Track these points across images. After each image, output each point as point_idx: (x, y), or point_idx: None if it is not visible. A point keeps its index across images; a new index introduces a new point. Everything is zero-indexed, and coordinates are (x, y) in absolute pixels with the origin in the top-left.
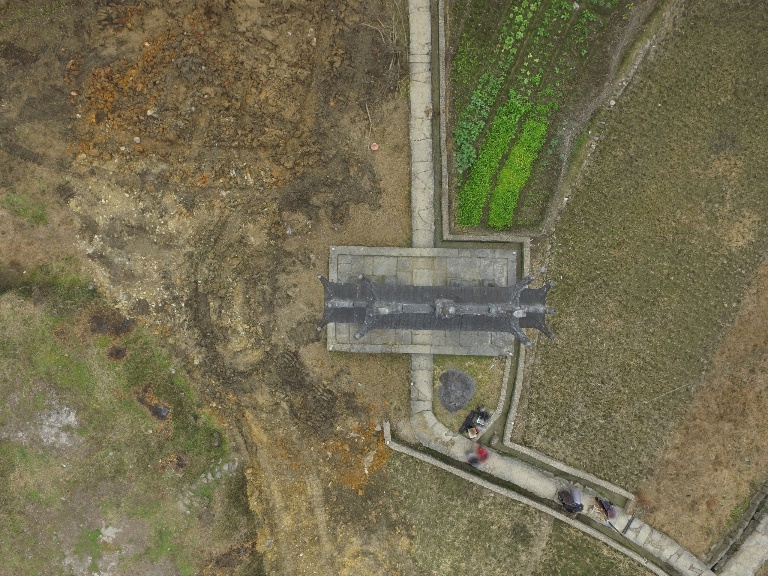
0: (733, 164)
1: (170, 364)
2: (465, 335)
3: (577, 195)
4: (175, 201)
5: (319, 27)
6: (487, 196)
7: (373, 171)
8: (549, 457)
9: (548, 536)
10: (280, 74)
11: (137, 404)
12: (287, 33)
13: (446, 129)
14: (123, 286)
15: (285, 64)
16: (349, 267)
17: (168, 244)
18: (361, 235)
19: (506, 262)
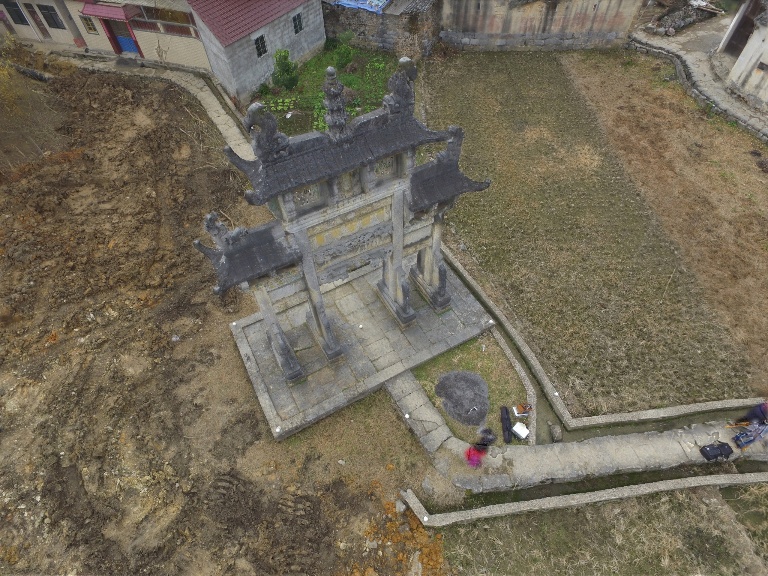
0: (539, 131)
1: None
2: (431, 331)
3: None
4: (15, 377)
5: (155, 185)
6: None
7: None
8: (632, 412)
9: (738, 522)
10: (126, 224)
11: None
12: (125, 199)
13: None
14: None
15: (129, 217)
16: (261, 334)
17: (7, 428)
18: None
19: None
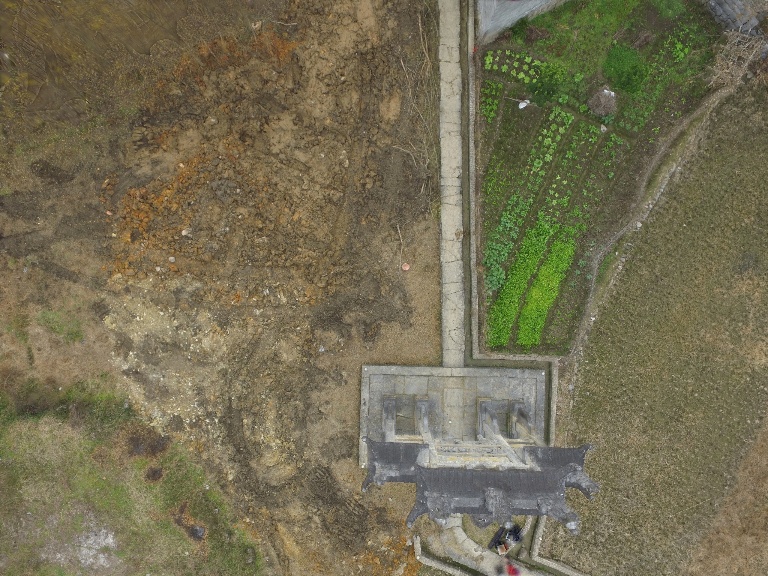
0: (756, 284)
1: (204, 480)
2: None
3: (604, 313)
4: (209, 319)
5: (351, 149)
6: (516, 314)
7: (404, 290)
8: (576, 570)
9: None
10: (313, 195)
11: (174, 526)
12: (320, 155)
13: (477, 252)
14: (158, 403)
15: (318, 185)
16: (381, 386)
17: (202, 361)
18: (392, 353)
19: (535, 382)
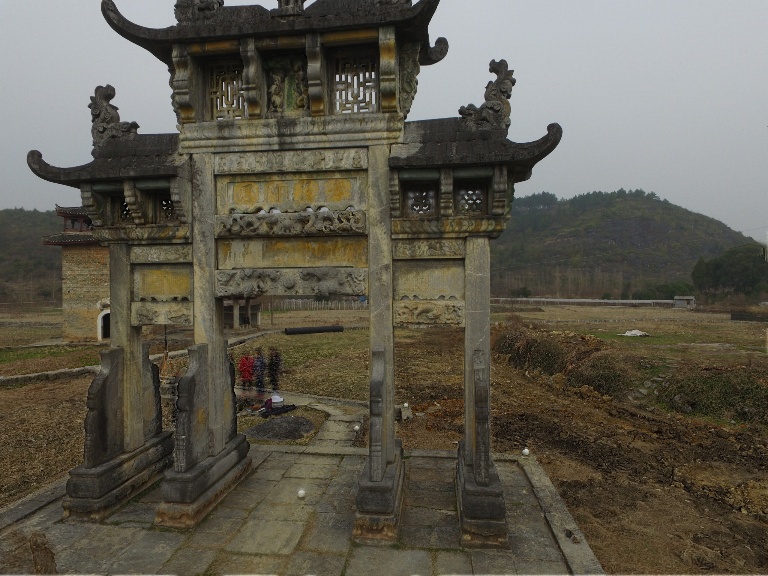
0: None
1: None
2: None
3: None
4: None
5: None
6: None
7: None
8: None
9: None
10: None
11: None
12: None
13: None
14: None
15: None
16: (526, 573)
17: None
18: None
19: None
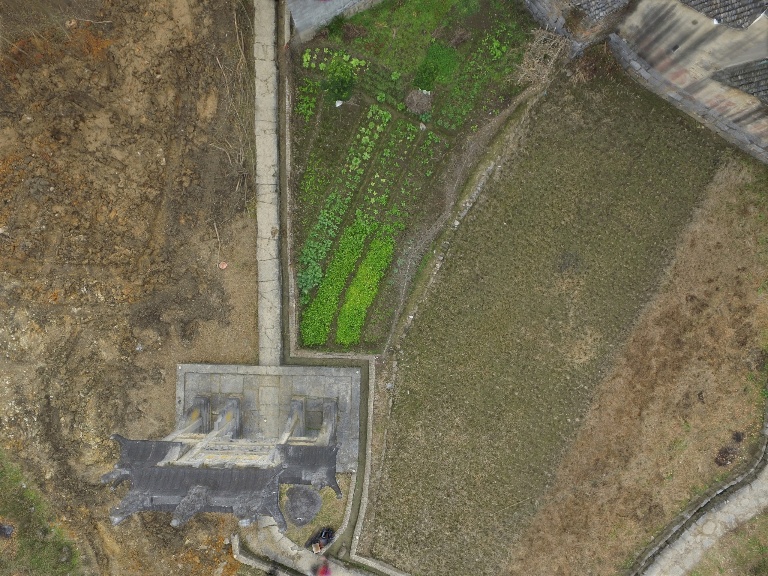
0: (576, 282)
1: (21, 479)
2: None
3: (424, 311)
4: (27, 317)
5: (169, 147)
6: (335, 313)
7: (222, 289)
8: (395, 569)
9: None
10: (130, 193)
11: None
12: (137, 153)
13: None
14: None
15: (135, 184)
16: (196, 385)
17: (20, 360)
18: (210, 352)
19: (350, 380)
